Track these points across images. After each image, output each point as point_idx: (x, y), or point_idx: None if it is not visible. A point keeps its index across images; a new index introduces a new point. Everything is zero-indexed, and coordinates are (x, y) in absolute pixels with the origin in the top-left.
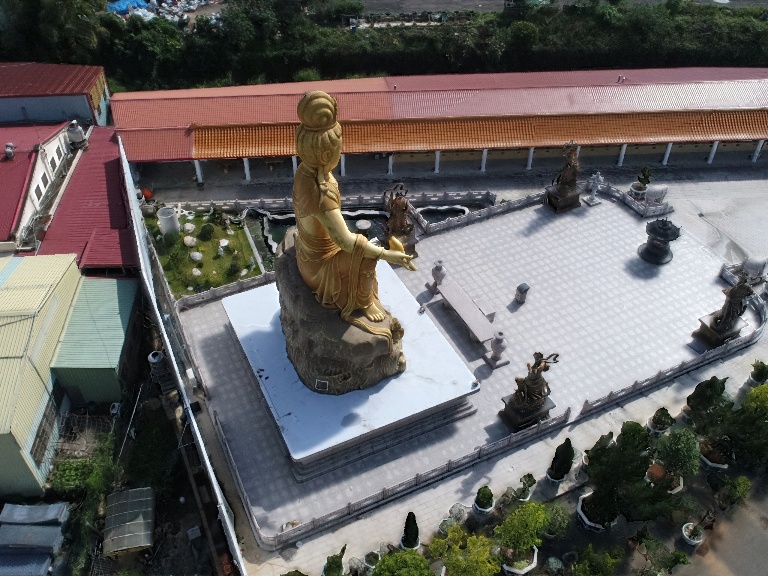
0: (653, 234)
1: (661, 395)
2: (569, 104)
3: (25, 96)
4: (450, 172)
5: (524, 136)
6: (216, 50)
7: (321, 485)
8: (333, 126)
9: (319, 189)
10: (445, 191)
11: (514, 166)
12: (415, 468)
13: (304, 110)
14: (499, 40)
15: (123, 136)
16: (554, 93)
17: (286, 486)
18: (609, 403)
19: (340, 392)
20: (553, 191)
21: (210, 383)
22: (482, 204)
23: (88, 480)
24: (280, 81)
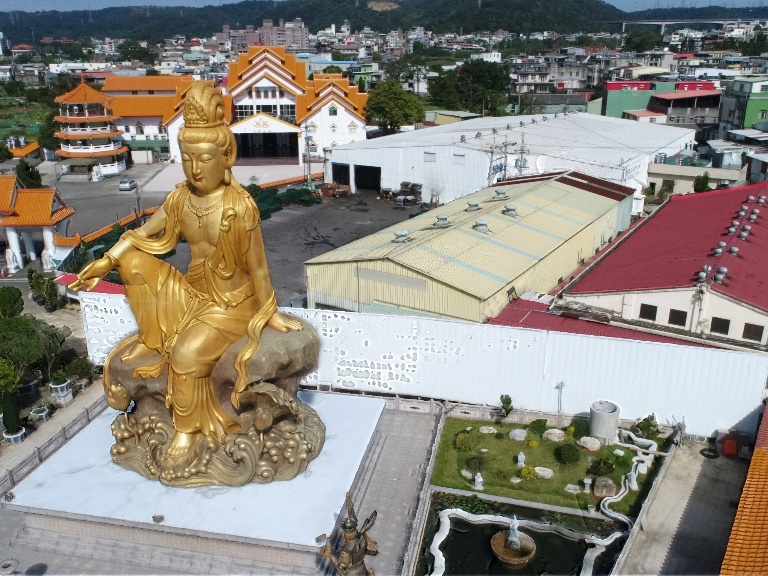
0: None
1: None
2: None
3: None
4: None
5: None
6: None
7: None
8: None
9: None
10: None
11: None
12: None
13: None
14: None
15: None
16: None
17: None
18: None
19: None
20: None
21: None
22: None
23: None
24: None
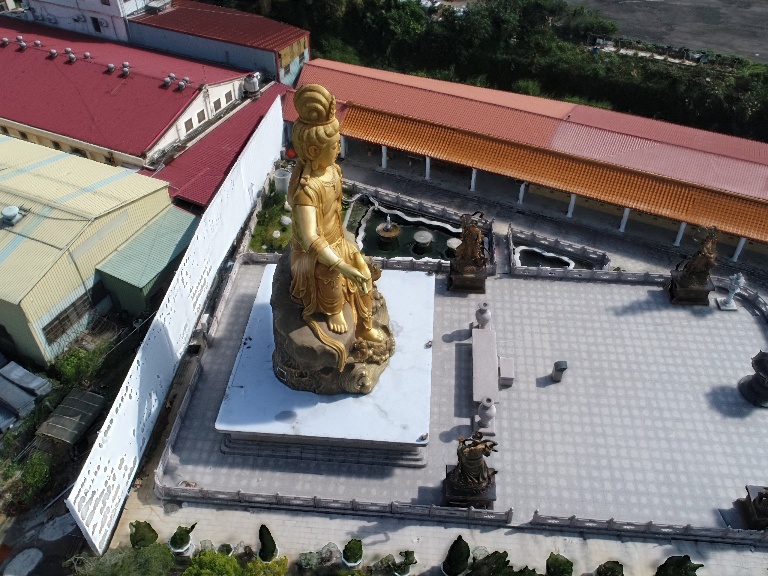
0: (757, 366)
1: (642, 549)
2: (763, 187)
3: (230, 42)
4: (584, 221)
5: (677, 206)
6: (450, 41)
7: (237, 464)
8: (325, 123)
9: (299, 181)
10: (557, 237)
11: (661, 237)
12: (326, 491)
13: (297, 100)
14: (756, 97)
15: (290, 97)
16: (751, 169)
17: (210, 450)
18: (571, 527)
19: (295, 387)
20: (676, 277)
21: (220, 334)
22: (594, 264)
23: (65, 369)
24: (500, 85)
